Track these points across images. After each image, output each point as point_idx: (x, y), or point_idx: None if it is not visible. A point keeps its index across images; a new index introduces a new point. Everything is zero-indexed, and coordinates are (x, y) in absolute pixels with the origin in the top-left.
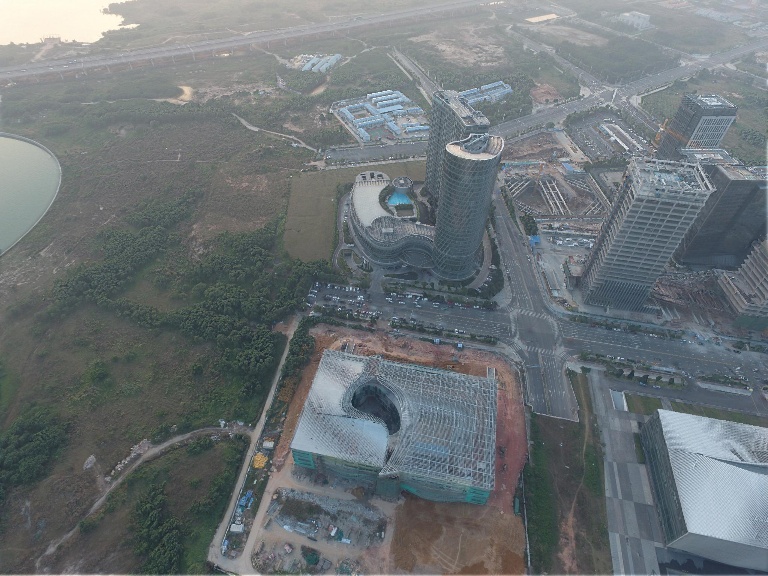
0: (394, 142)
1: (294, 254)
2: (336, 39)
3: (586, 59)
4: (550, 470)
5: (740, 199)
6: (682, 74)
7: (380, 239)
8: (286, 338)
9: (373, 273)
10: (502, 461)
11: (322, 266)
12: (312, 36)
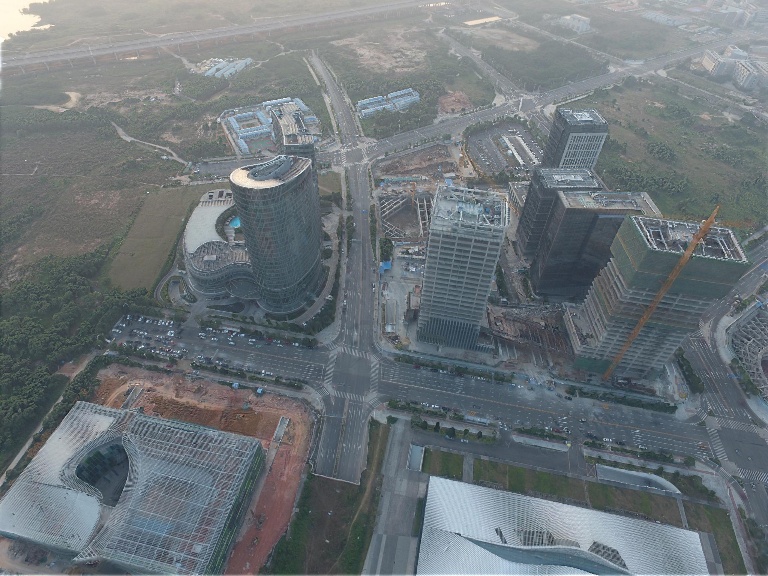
0: (275, 154)
1: (116, 282)
2: (253, 42)
3: (508, 65)
4: (306, 545)
5: (582, 228)
6: (608, 81)
7: (199, 268)
8: (68, 381)
9: (196, 304)
10: (256, 533)
11: (137, 297)
12: (229, 39)
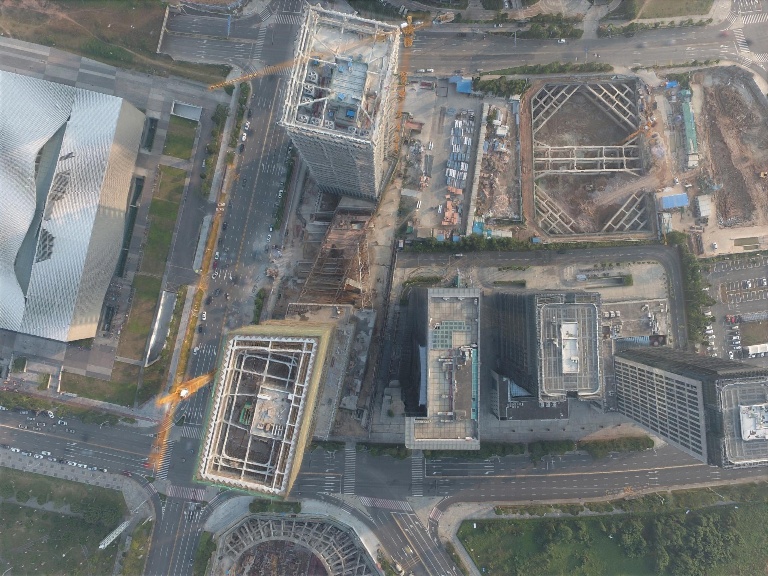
0: None
1: None
2: None
3: None
4: (106, 7)
5: None
6: None
7: None
8: None
9: None
10: None
11: None
12: None
